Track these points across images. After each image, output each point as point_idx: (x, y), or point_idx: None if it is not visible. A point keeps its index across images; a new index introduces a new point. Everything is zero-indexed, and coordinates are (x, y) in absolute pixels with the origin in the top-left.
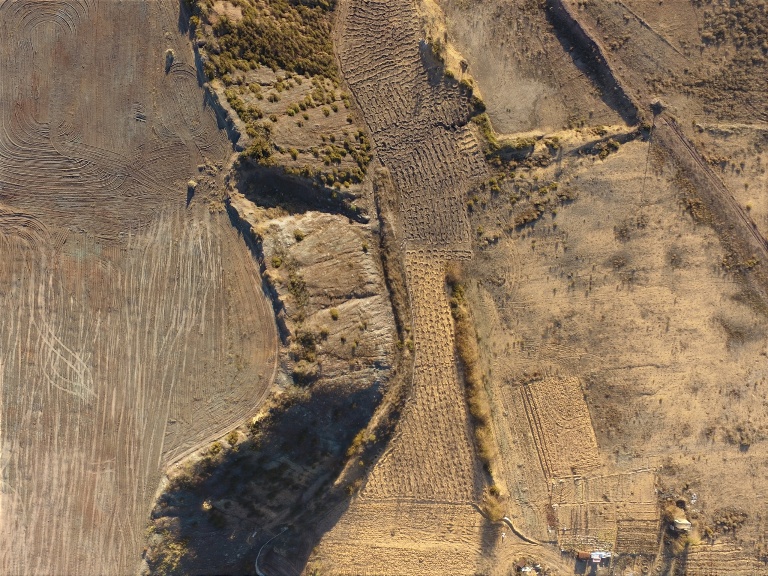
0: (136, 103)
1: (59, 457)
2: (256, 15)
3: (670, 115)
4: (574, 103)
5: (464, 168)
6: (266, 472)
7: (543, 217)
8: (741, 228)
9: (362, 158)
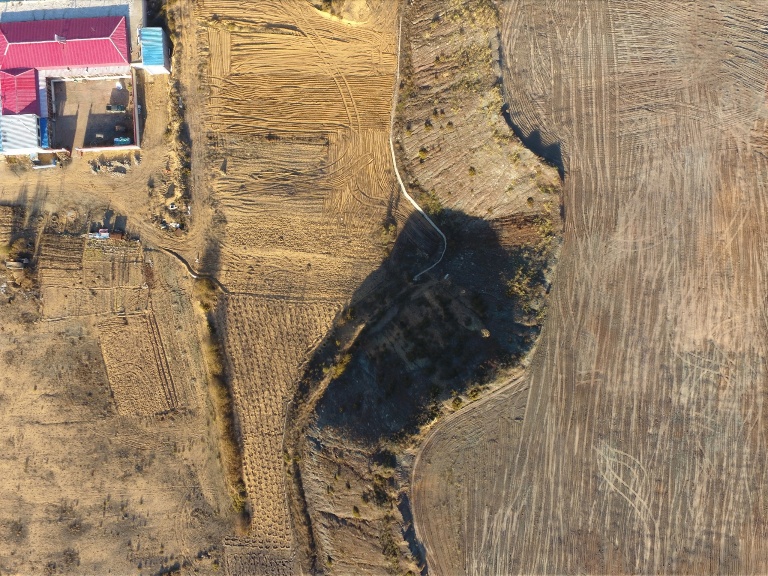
0: None
1: (632, 387)
2: None
3: None
4: None
5: None
6: (429, 355)
7: None
8: None
9: None
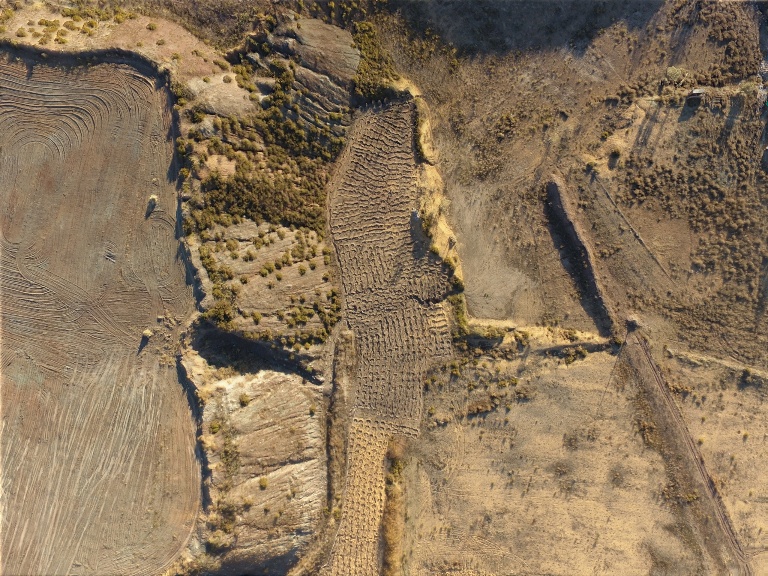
0: (109, 242)
1: None
2: (250, 169)
3: (643, 335)
4: (553, 301)
5: (429, 346)
6: None
7: (497, 410)
8: (689, 461)
9: (330, 319)
